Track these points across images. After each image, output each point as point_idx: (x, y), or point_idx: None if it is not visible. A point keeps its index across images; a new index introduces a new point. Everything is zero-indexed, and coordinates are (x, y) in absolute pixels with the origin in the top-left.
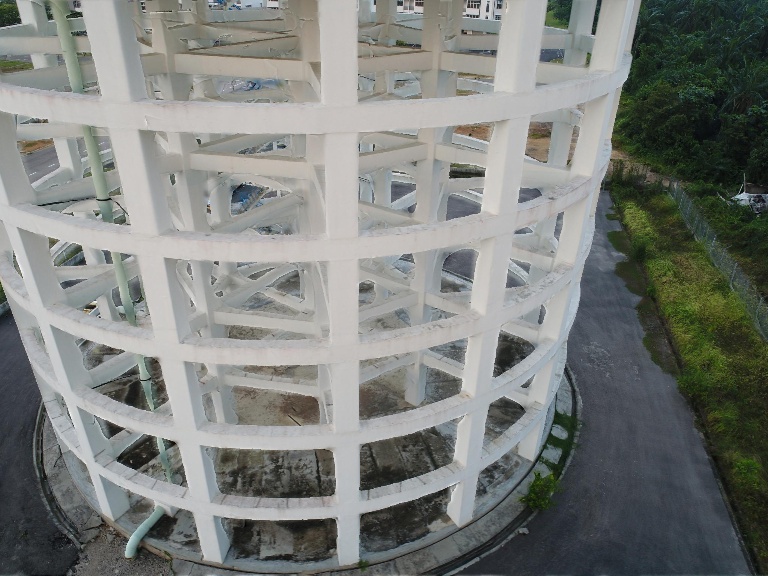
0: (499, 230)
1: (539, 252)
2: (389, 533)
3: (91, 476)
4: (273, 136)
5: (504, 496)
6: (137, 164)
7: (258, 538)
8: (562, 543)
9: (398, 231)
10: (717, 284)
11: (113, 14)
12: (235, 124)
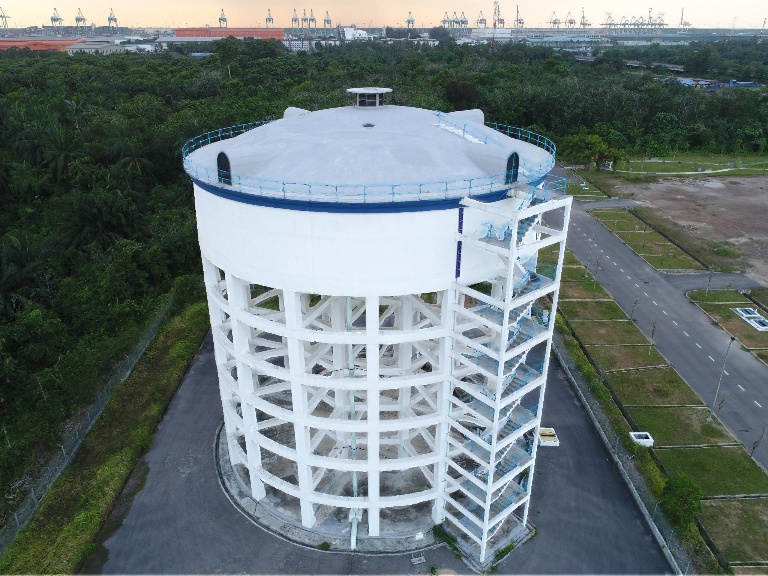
0: None
1: None
2: None
3: None
4: None
5: None
6: None
7: None
8: None
9: None
10: None
11: None
12: None
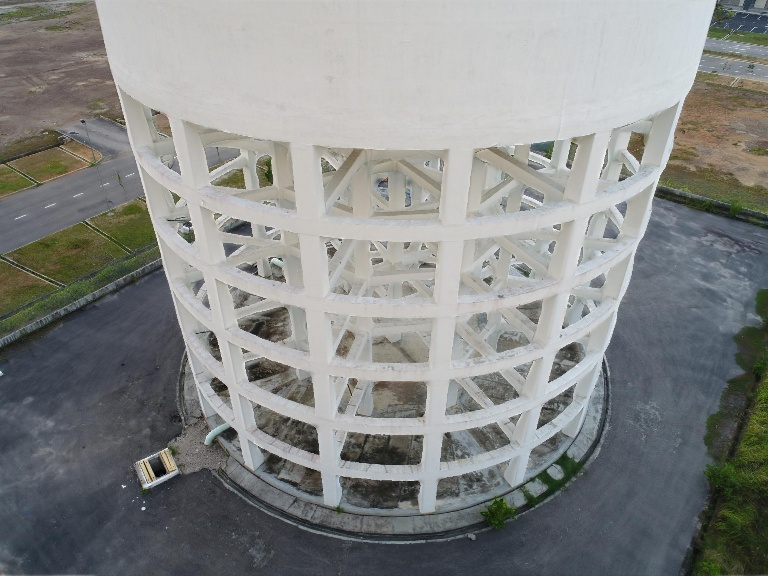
0: (440, 314)
1: (529, 324)
2: (369, 496)
3: (196, 385)
4: None
5: (471, 505)
6: (200, 223)
7: (283, 464)
8: (497, 559)
9: (354, 300)
10: None
11: (186, 143)
12: (246, 216)
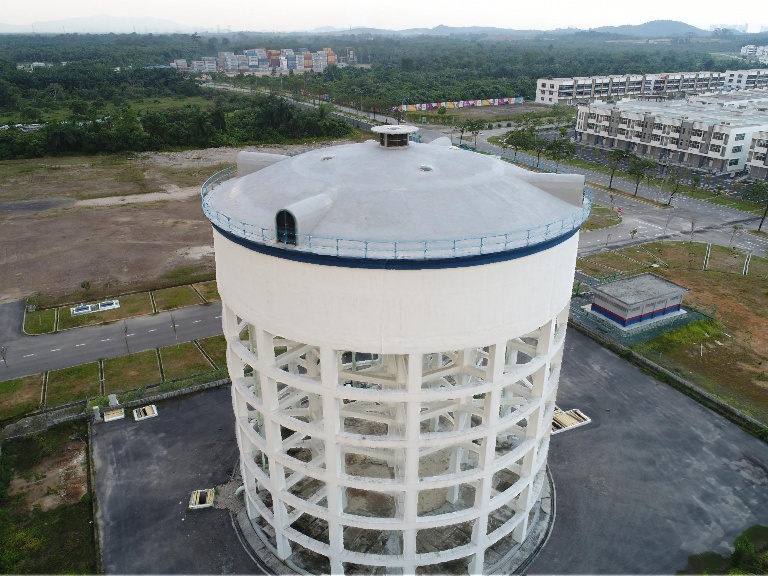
0: (326, 439)
1: None
2: (307, 562)
3: None
4: None
5: None
6: None
7: None
8: None
9: (285, 417)
10: None
11: None
12: (242, 357)
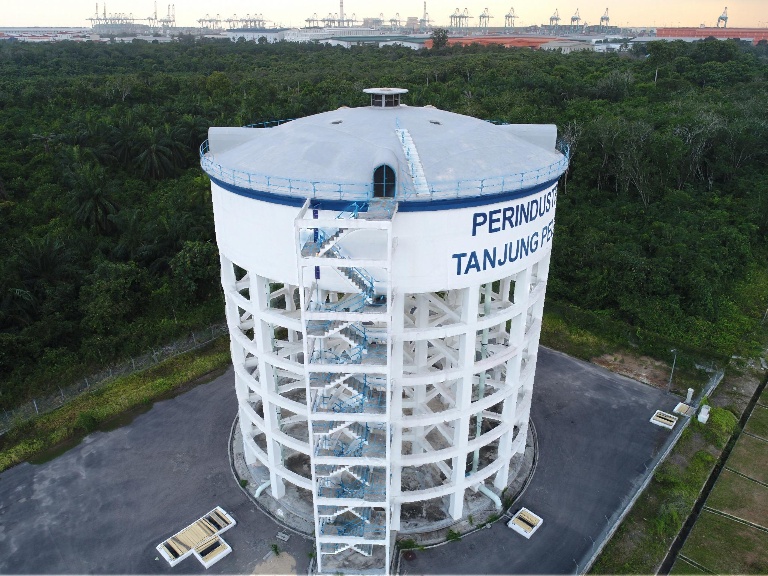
0: None
1: None
2: None
3: None
4: None
5: None
6: None
7: None
8: None
9: None
10: (98, 393)
11: None
12: None
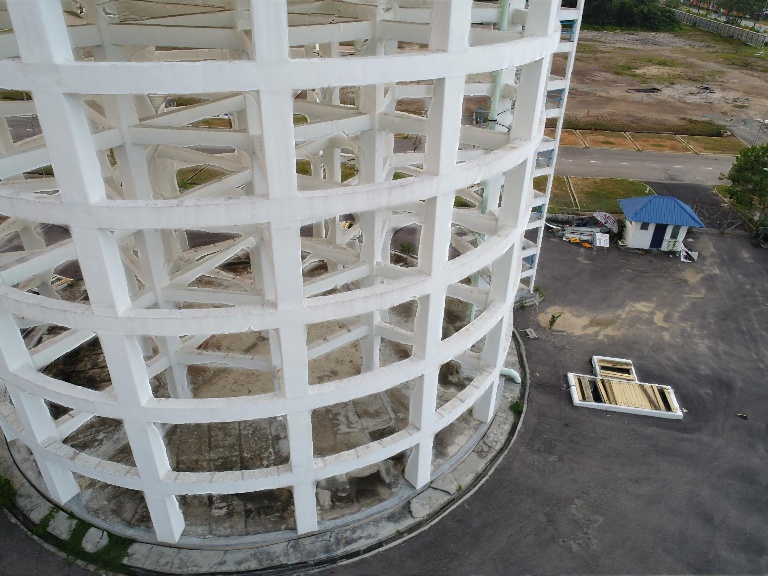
0: None
1: (13, 262)
2: None
3: None
4: (205, 95)
5: None
6: None
7: (61, 332)
8: None
9: None
10: None
11: None
12: None
